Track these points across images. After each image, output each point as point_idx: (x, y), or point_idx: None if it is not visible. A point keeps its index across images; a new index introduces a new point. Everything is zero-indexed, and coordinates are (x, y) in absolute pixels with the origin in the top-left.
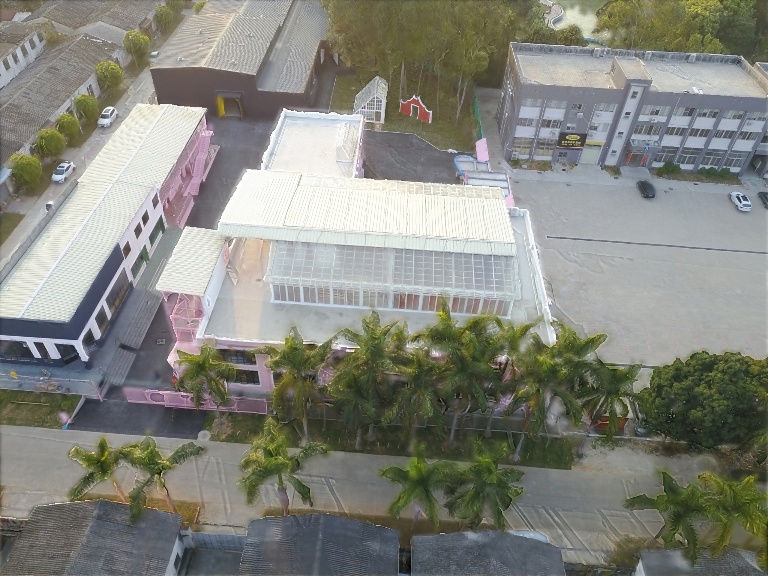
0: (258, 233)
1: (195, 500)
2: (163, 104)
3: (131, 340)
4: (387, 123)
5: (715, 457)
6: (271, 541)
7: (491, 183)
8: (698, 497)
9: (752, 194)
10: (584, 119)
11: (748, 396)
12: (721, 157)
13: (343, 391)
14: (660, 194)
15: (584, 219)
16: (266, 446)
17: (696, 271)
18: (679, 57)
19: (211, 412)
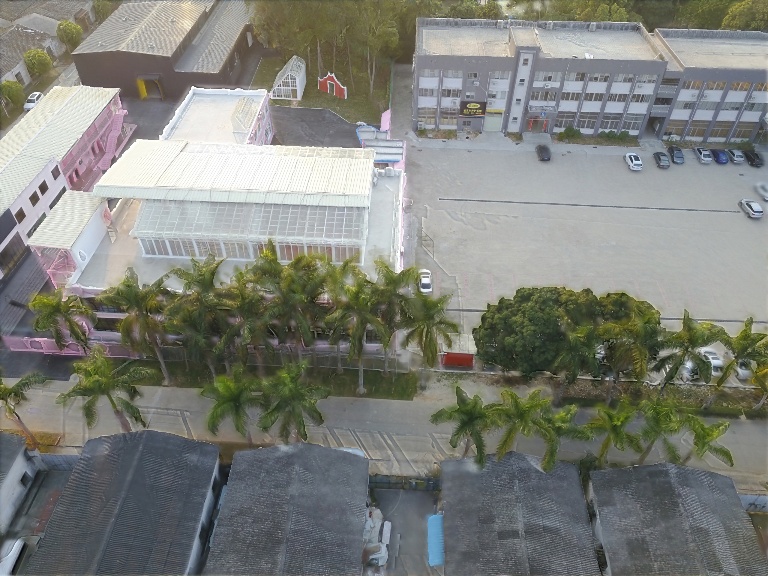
0: (130, 193)
1: (57, 431)
2: (77, 86)
3: (22, 297)
4: (304, 100)
5: (552, 387)
6: (100, 455)
7: (387, 150)
8: (480, 405)
9: (648, 155)
10: (481, 87)
11: (552, 321)
12: (619, 120)
13: (176, 324)
14: (557, 157)
15: (478, 182)
16: (86, 367)
17: (576, 226)
18: (580, 26)
19: (86, 357)
